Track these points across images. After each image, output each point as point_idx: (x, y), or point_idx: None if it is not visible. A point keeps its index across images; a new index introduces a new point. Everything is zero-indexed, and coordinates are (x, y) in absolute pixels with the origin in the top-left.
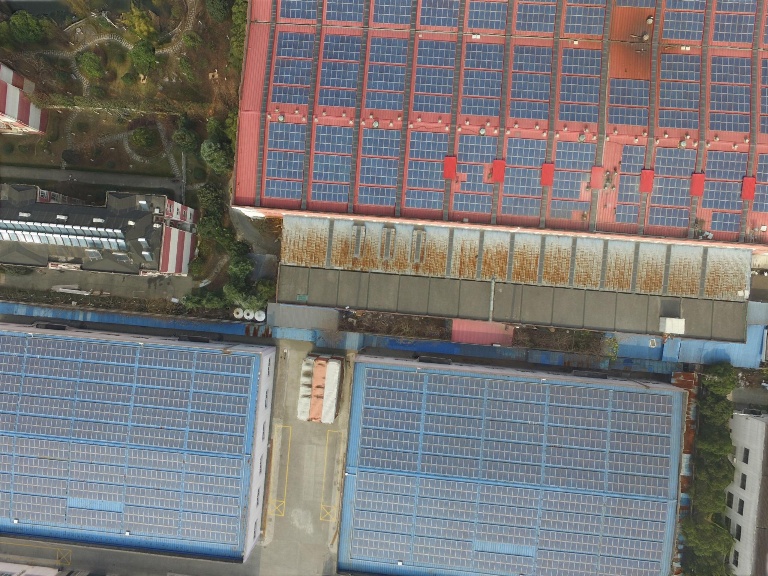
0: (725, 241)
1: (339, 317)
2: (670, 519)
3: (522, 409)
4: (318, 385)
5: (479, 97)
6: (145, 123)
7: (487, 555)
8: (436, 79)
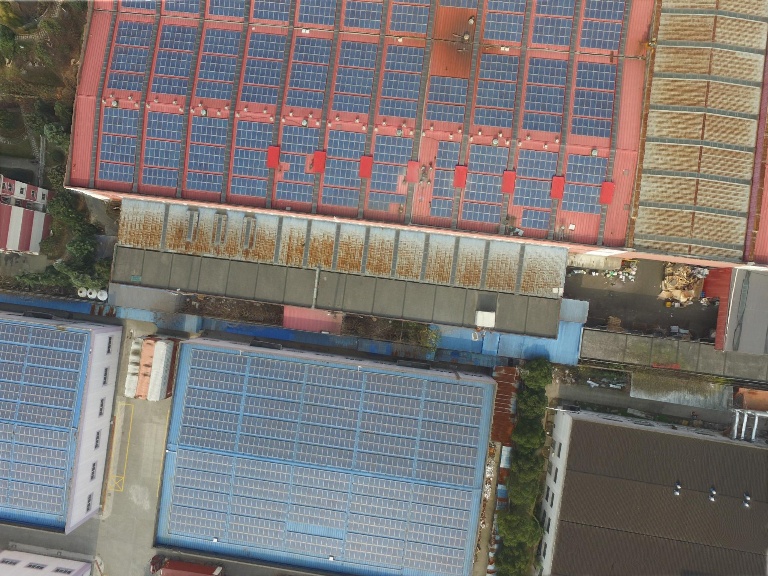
0: (535, 238)
1: (178, 299)
2: (475, 508)
3: (339, 395)
4: (145, 364)
5: (304, 90)
6: (8, 105)
7: (298, 536)
8: (265, 71)
